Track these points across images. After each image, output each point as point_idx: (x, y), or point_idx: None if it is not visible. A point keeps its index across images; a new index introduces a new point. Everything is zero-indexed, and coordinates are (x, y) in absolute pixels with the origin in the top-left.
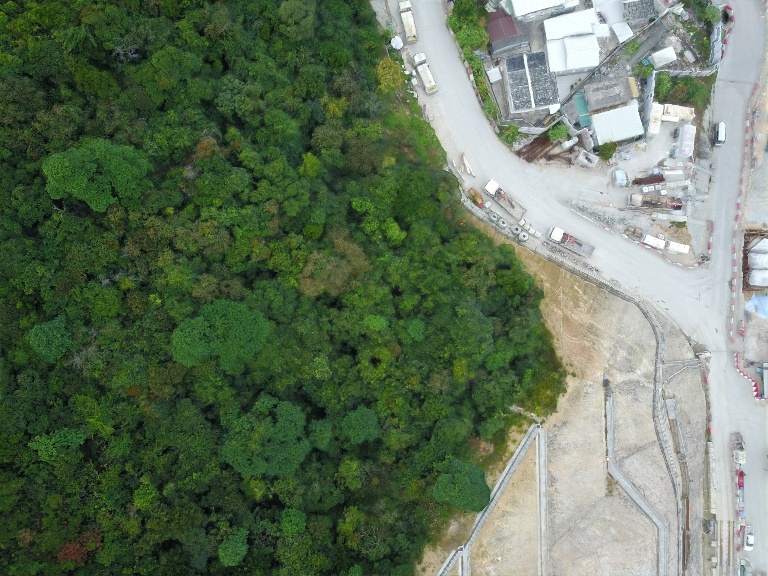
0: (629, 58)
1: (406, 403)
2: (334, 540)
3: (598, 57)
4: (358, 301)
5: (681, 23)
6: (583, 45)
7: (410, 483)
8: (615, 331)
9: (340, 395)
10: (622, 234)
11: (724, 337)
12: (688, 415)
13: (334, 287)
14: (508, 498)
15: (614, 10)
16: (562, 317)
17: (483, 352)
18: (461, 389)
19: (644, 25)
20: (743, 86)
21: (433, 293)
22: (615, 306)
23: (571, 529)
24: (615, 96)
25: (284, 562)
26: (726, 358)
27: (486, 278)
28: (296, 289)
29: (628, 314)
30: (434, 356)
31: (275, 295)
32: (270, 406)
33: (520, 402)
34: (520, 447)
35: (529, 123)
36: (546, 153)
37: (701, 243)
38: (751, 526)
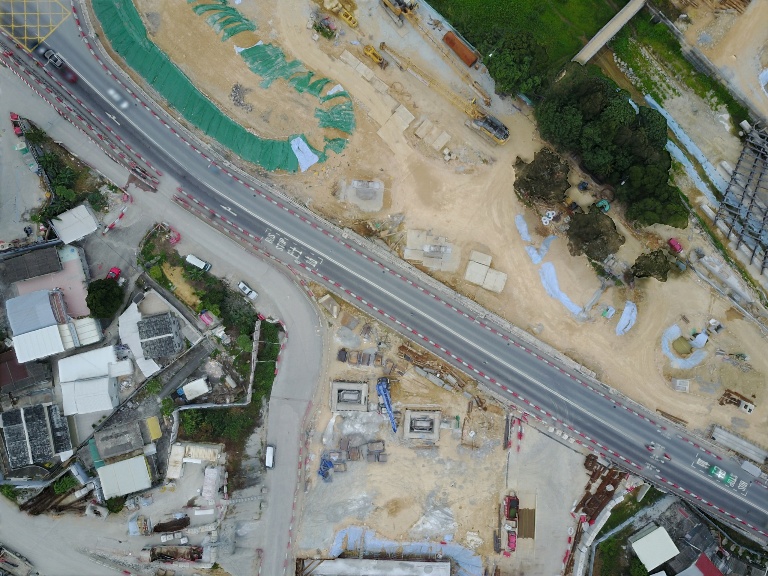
0: (160, 390)
1: None
2: None
3: (110, 402)
4: None
5: (224, 346)
6: (92, 391)
7: None
8: None
9: None
10: None
11: None
12: None
13: None
14: None
15: (140, 343)
16: None
17: None
18: None
19: (182, 350)
20: (298, 403)
21: None
22: None
23: None
24: (126, 444)
25: None
26: None
27: None
28: None
29: None
30: None
31: None
32: None
33: None
34: None
35: (43, 469)
36: (55, 504)
37: (249, 575)
38: None
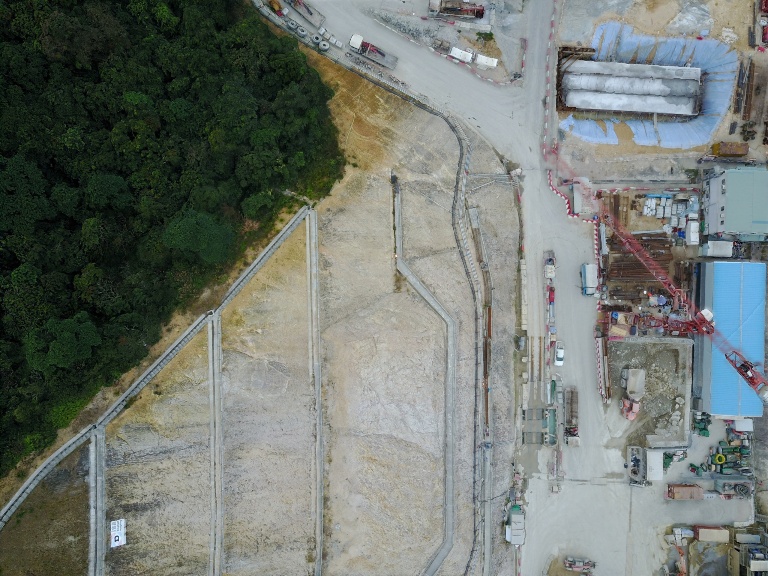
0: None
1: (164, 176)
2: (70, 296)
3: None
4: (115, 74)
5: None
6: None
7: (155, 244)
8: (415, 138)
9: (91, 164)
10: (429, 47)
11: (538, 156)
12: (495, 228)
13: (82, 52)
14: (270, 273)
15: None
16: (354, 118)
17: (243, 125)
18: (222, 163)
19: None
20: None
21: (202, 75)
22: (419, 117)
23: (349, 317)
24: None
25: (8, 308)
26: (540, 177)
27: (256, 60)
28: (43, 54)
29: (433, 126)
30: (198, 134)
31: (13, 53)
32: (3, 161)
33: (293, 186)
34: (287, 226)
35: None
36: None
37: (514, 61)
38: (562, 341)
